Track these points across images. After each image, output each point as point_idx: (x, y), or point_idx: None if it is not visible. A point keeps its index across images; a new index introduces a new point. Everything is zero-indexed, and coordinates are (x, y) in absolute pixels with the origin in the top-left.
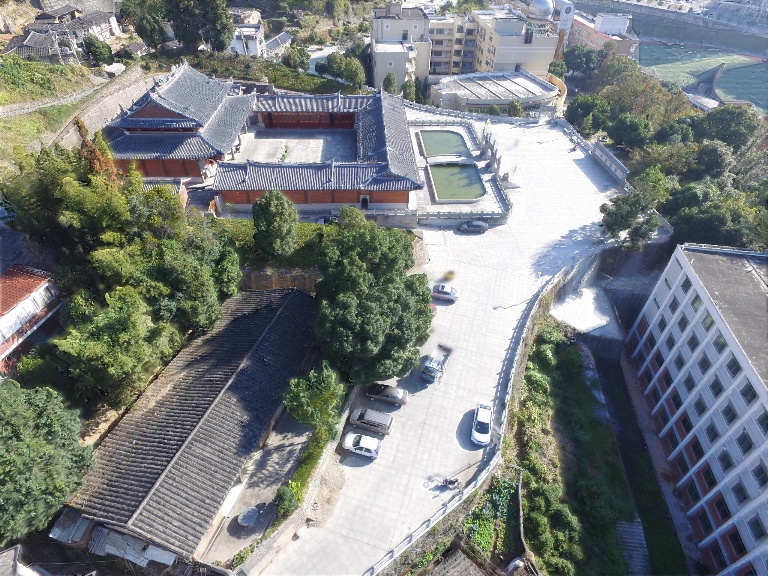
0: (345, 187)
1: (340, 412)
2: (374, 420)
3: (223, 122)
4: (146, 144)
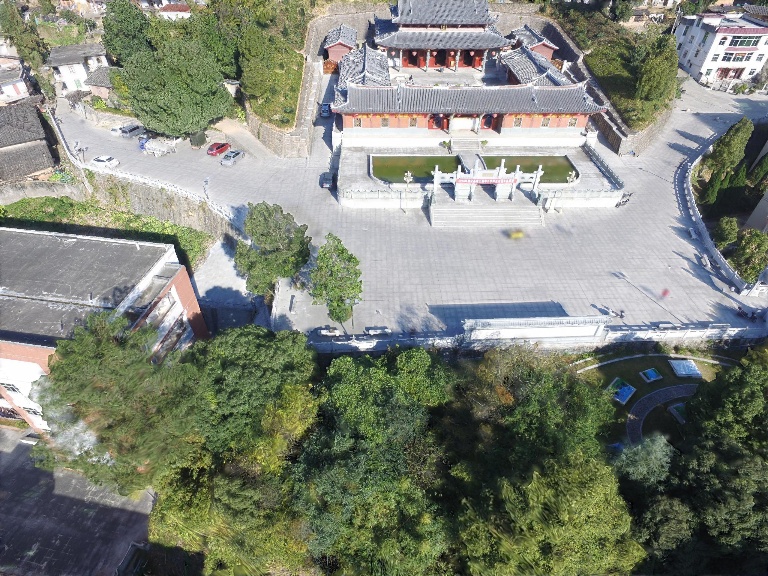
0: None
1: None
2: None
3: (436, 38)
4: None
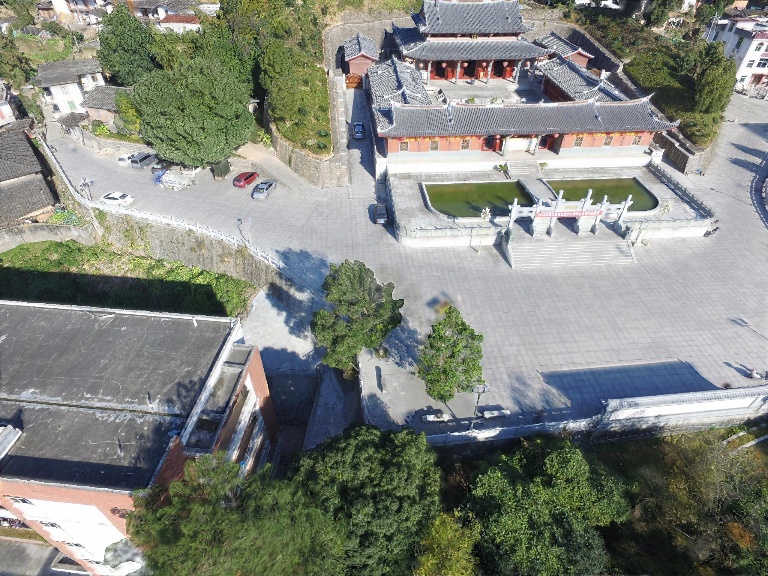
0: (377, 105)
1: (151, 144)
2: (138, 154)
3: (467, 48)
4: (411, 36)
